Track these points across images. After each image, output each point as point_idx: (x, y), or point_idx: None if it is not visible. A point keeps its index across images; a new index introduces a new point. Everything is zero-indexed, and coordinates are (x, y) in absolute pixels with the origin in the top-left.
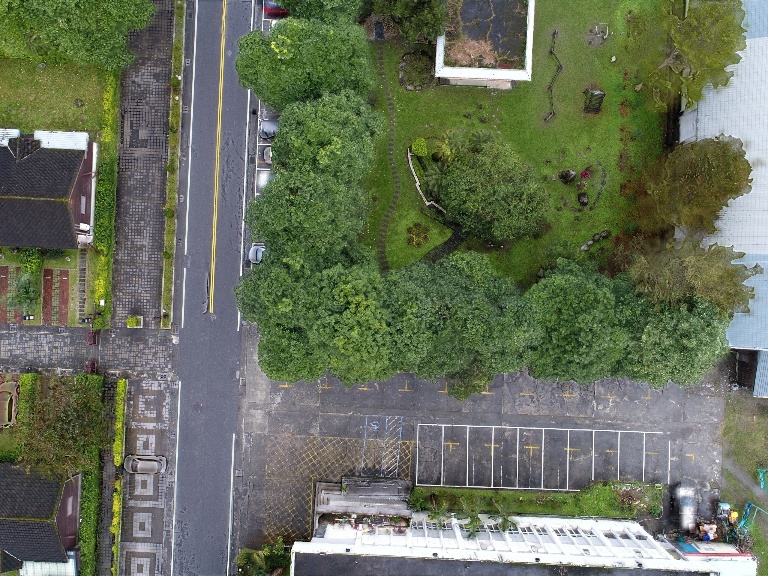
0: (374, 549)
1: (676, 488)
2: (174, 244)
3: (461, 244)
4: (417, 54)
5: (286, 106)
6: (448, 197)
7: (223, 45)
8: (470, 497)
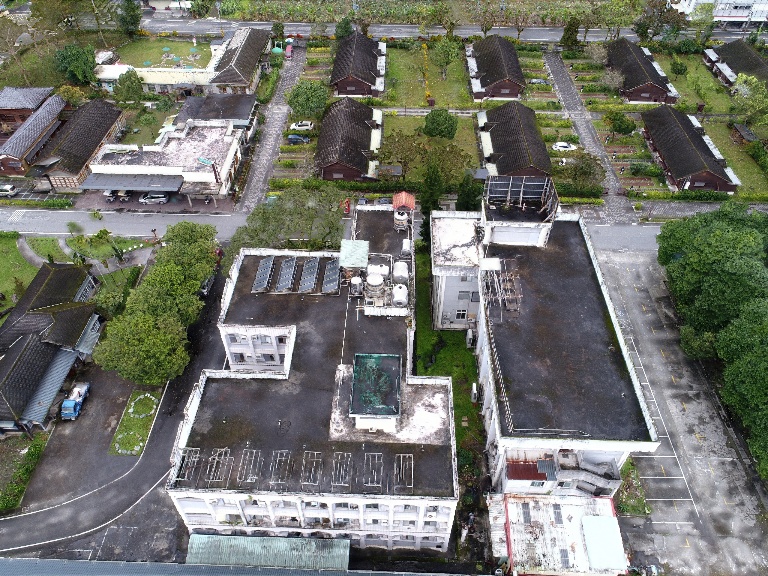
0: None
1: (651, 529)
2: None
3: None
4: None
5: None
6: None
7: None
8: None
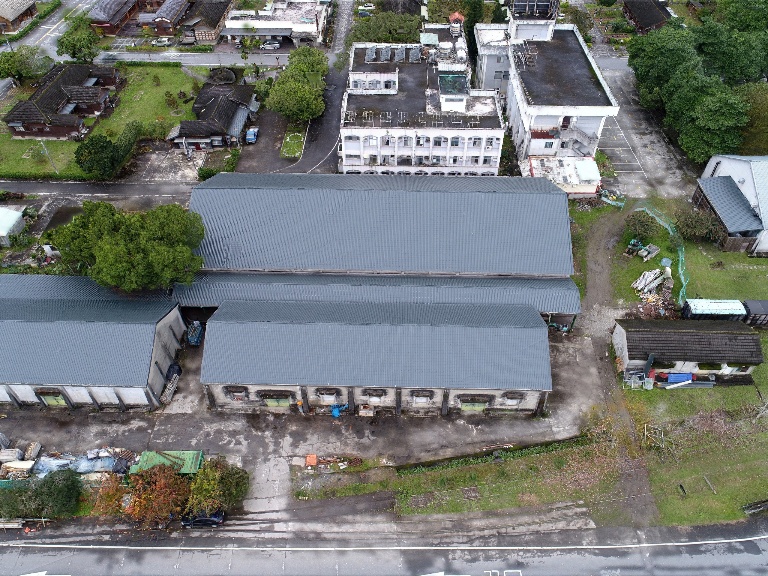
0: None
1: (617, 182)
2: None
3: None
4: None
5: None
6: None
7: None
8: None
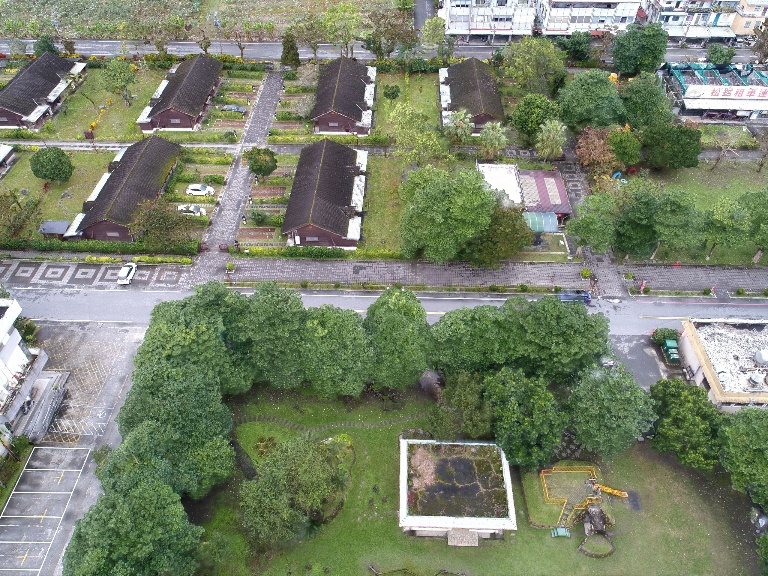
0: None
1: None
2: None
3: None
4: None
5: None
6: None
7: (429, 313)
8: (1, 491)
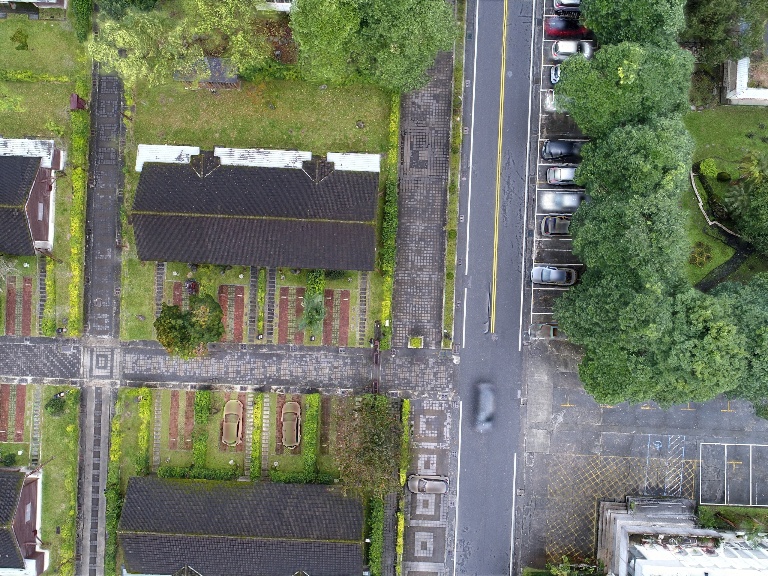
0: (728, 573)
1: None
2: (455, 264)
3: (743, 263)
4: (700, 74)
5: (613, 130)
6: (753, 218)
7: (503, 66)
8: (757, 516)
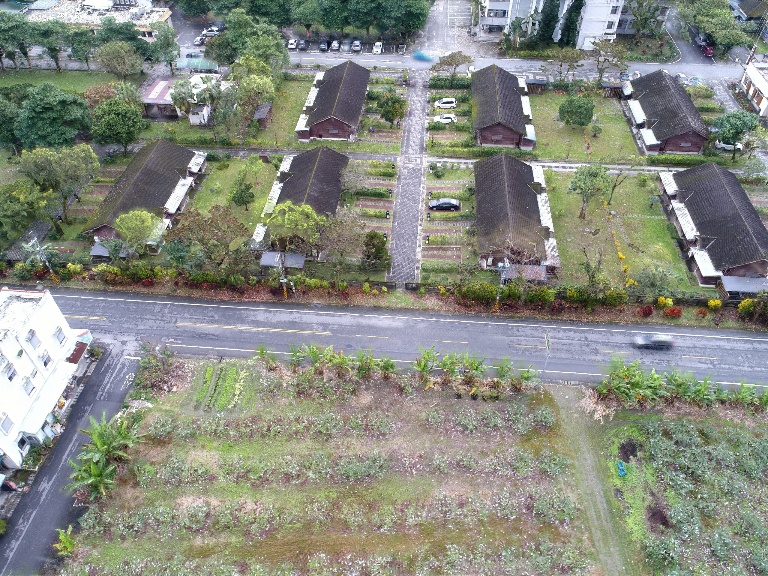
0: None
1: None
2: (370, 69)
3: None
4: None
5: None
6: None
7: None
8: None
